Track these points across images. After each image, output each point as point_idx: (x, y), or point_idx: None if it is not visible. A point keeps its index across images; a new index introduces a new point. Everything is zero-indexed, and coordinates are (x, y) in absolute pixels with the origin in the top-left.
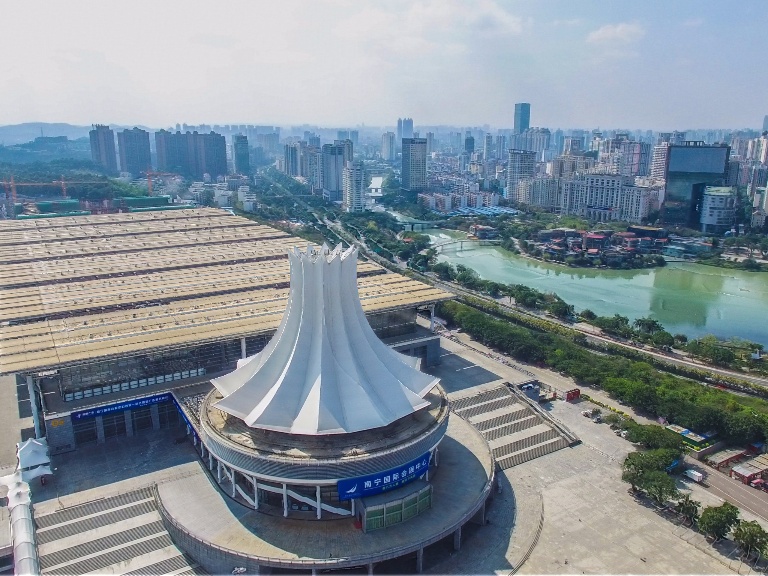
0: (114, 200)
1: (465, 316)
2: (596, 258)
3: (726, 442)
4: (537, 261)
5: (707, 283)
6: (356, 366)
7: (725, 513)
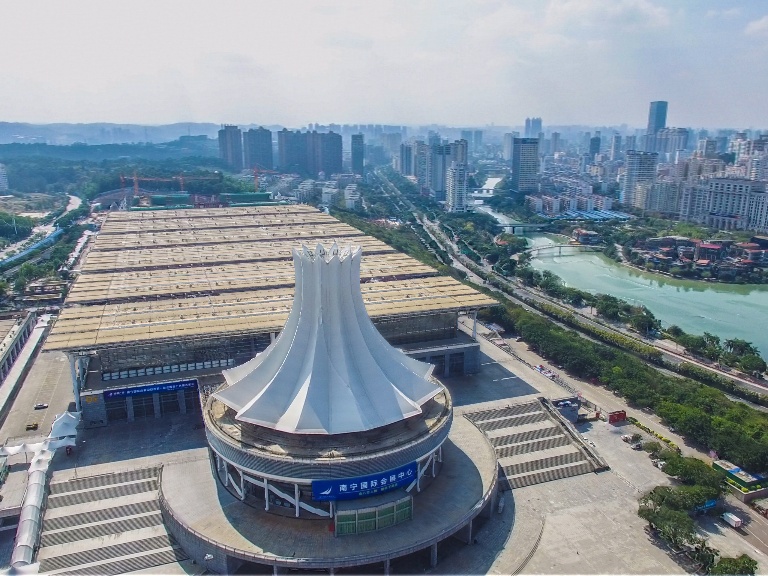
0: (220, 195)
1: (526, 324)
2: (705, 270)
3: None
4: (639, 270)
5: None
6: (350, 368)
7: (739, 566)
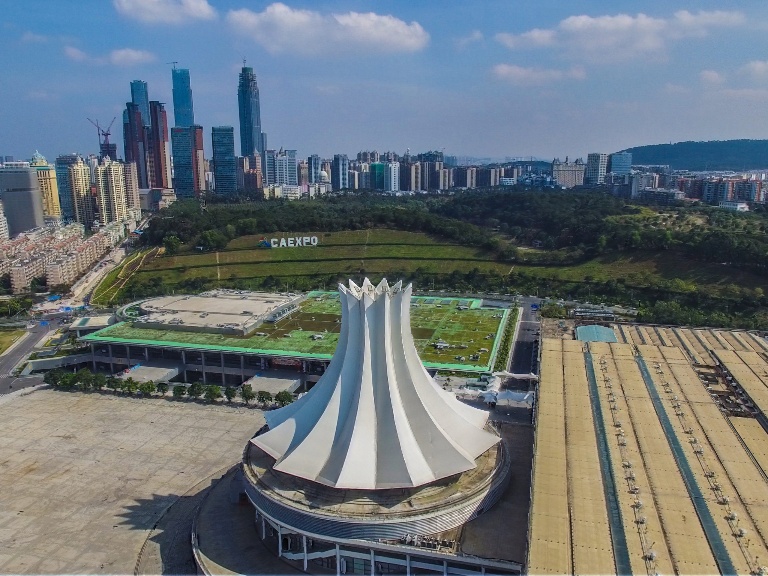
0: None
1: None
2: None
3: None
4: None
5: None
6: None
7: None
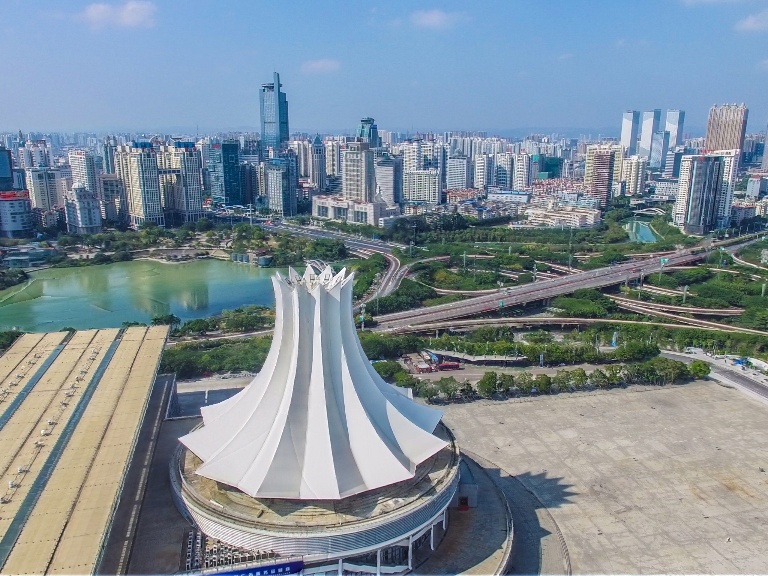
0: None
1: None
2: None
3: (389, 358)
4: None
5: (30, 290)
6: None
7: (495, 376)
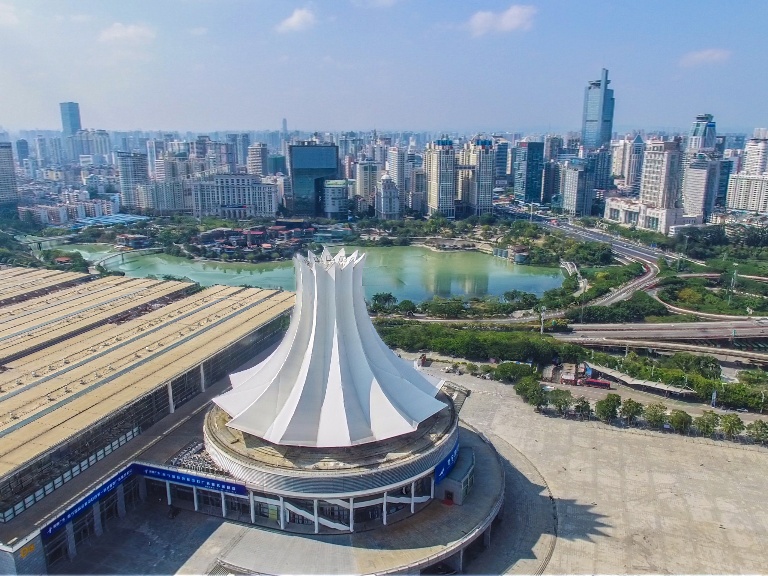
0: None
1: None
2: (273, 252)
3: (540, 363)
4: (217, 262)
5: None
6: None
7: (616, 400)
